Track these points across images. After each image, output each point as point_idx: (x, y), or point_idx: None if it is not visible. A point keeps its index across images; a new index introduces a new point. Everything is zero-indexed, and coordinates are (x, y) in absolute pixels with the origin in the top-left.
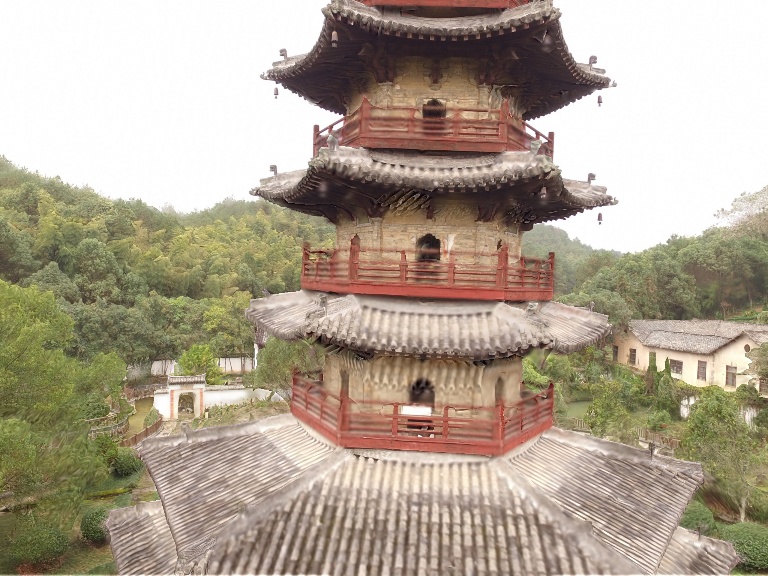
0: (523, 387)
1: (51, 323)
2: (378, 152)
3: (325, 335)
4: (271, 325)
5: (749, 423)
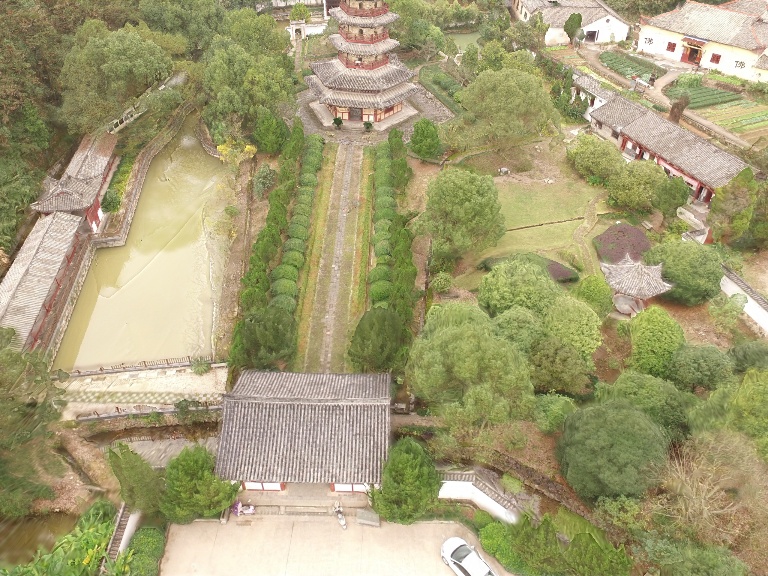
0: (385, 54)
1: None
2: (351, 15)
3: (342, 51)
4: (334, 43)
5: None
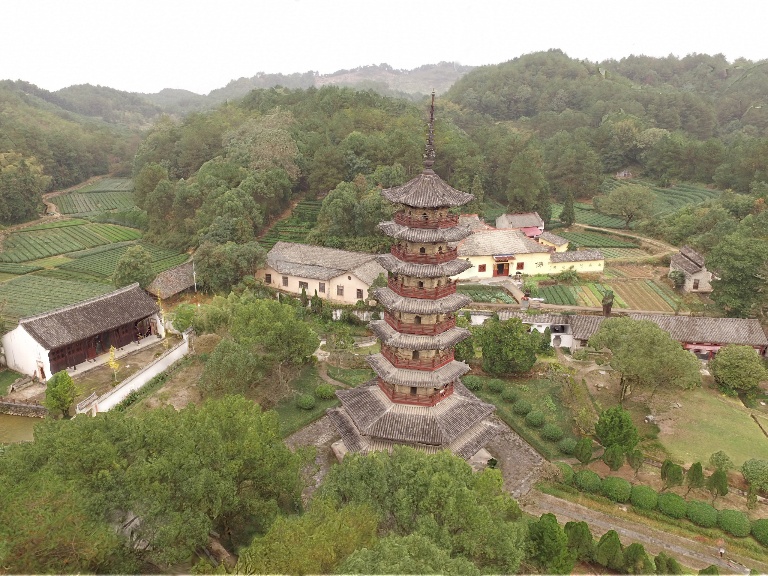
0: None
1: None
2: None
3: None
4: (405, 383)
5: (366, 318)
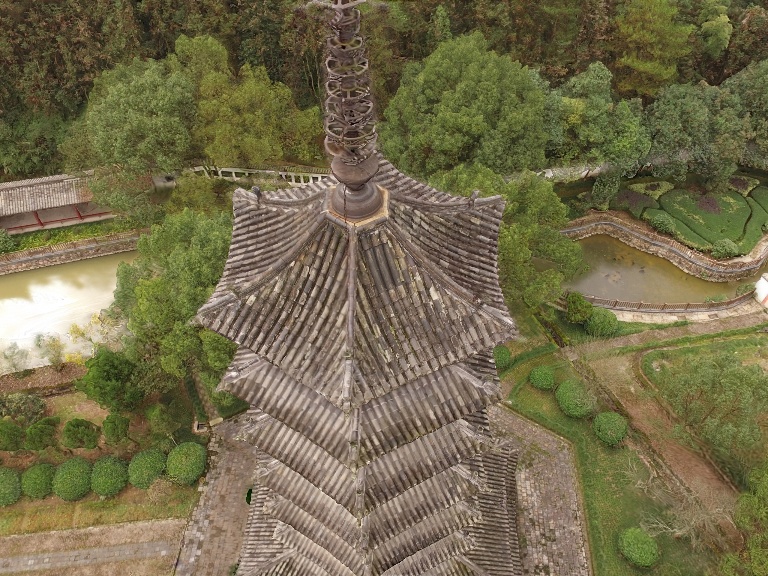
0: None
1: (504, 255)
2: None
3: None
4: None
5: None
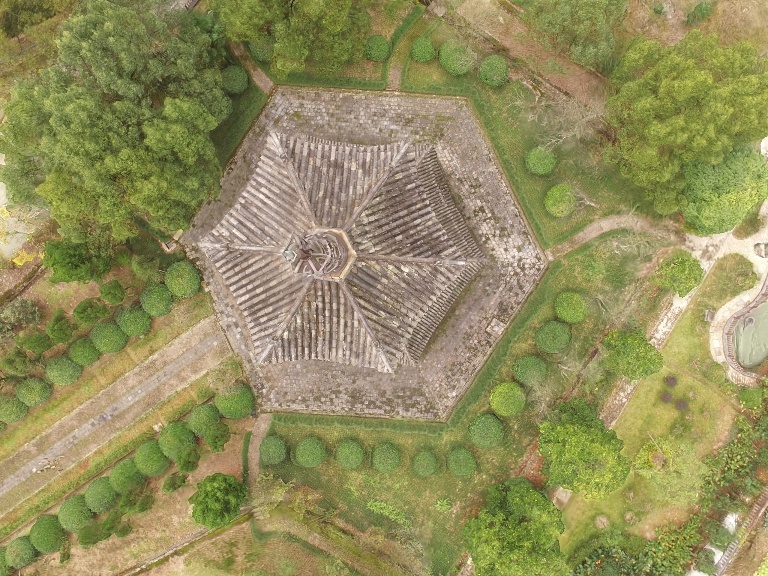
0: None
1: None
2: None
3: None
4: None
5: None
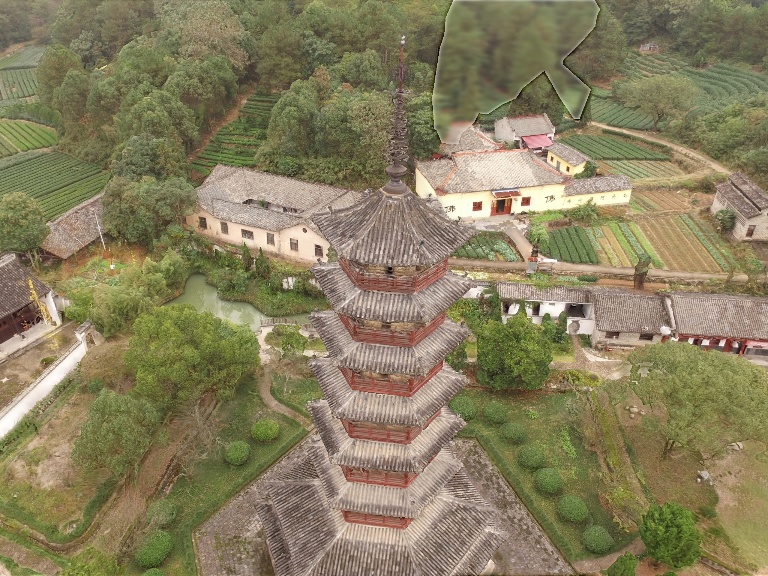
0: None
1: None
2: None
3: None
4: (362, 510)
5: None
